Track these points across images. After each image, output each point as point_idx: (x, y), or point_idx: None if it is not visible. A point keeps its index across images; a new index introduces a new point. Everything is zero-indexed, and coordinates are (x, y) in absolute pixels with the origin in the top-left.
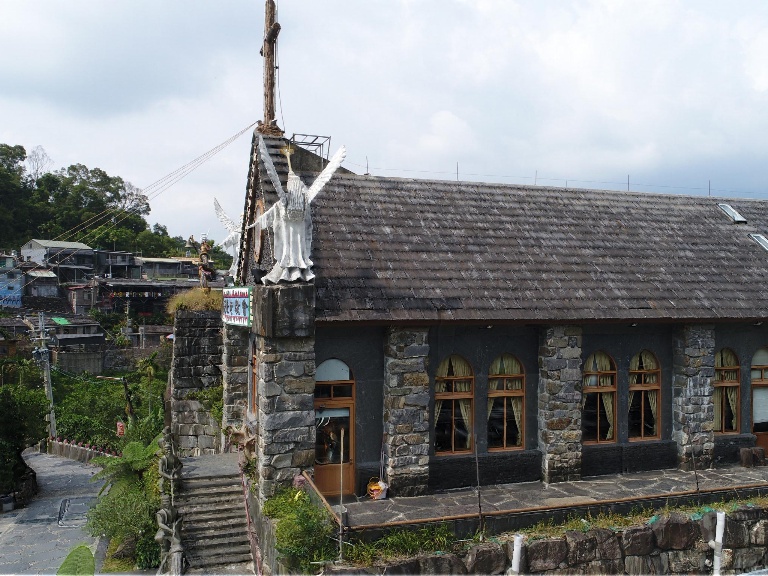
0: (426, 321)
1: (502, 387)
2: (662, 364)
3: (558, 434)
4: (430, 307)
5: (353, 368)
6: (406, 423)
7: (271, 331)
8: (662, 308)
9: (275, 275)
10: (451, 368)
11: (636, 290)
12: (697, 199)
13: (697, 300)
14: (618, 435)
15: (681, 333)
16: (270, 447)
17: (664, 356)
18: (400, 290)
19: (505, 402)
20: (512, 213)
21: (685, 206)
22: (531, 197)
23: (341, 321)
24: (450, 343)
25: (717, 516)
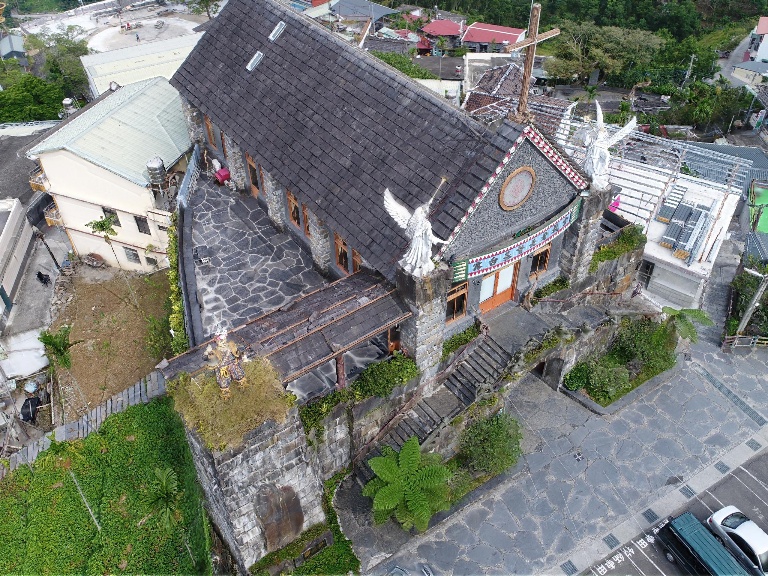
0: None
1: None
2: None
3: None
4: None
5: None
6: None
7: None
8: None
9: (603, 180)
10: None
11: None
12: None
13: None
14: None
15: None
16: None
17: None
18: None
19: None
20: None
21: None
22: None
23: None
24: None
25: None
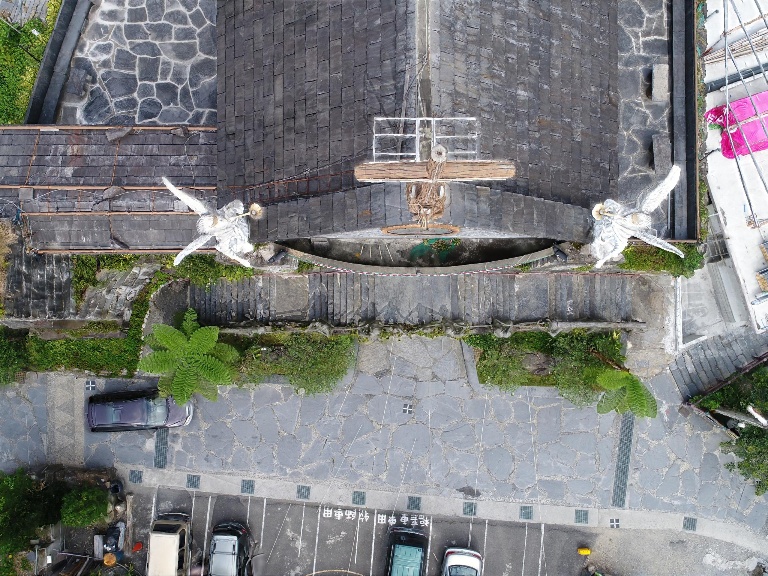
0: None
1: None
2: None
3: None
4: None
5: None
6: None
7: None
8: None
9: None
10: None
11: None
12: None
13: None
14: None
15: None
16: None
17: None
18: (593, 127)
19: None
20: None
21: None
22: None
23: None
24: None
25: None
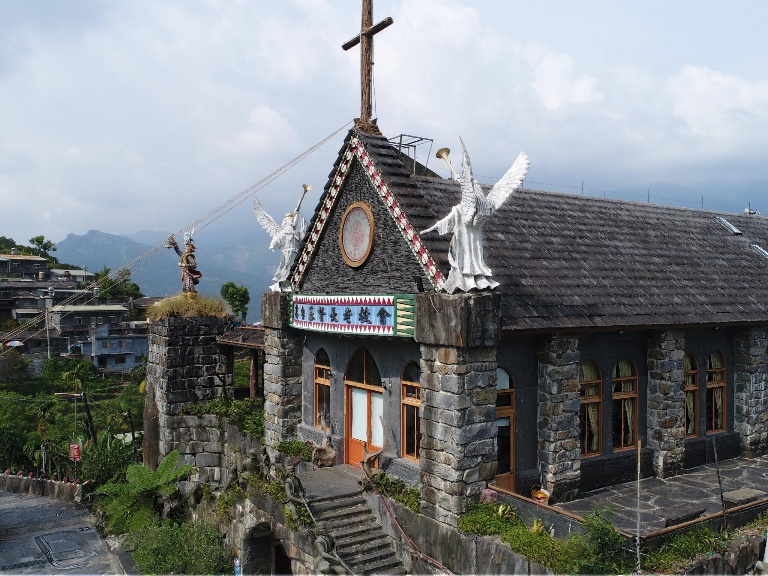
0: (585, 328)
1: (620, 390)
2: (728, 363)
3: (670, 432)
4: (582, 314)
5: (514, 376)
6: (564, 429)
7: (465, 341)
8: (737, 312)
9: (460, 283)
10: (582, 373)
11: (711, 296)
12: (699, 212)
13: (754, 305)
14: (700, 430)
15: (745, 334)
16: (462, 462)
17: (729, 356)
18: (549, 297)
19: (623, 404)
20: (583, 222)
21: (694, 218)
22: (587, 206)
23: (523, 330)
24: (586, 349)
25: None
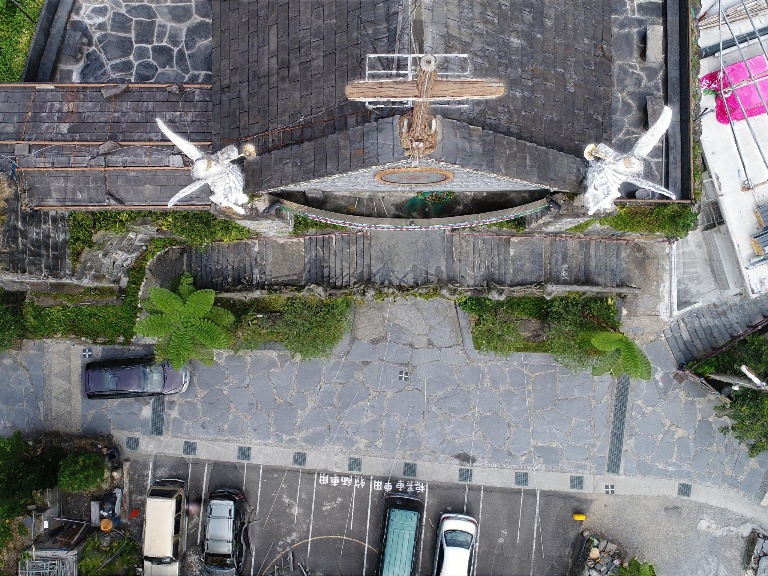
0: None
1: None
2: None
3: None
4: None
5: None
6: None
7: None
8: None
9: None
10: None
11: None
12: None
13: None
14: None
15: None
16: None
17: None
18: (587, 79)
19: None
20: None
21: None
22: None
23: None
24: None
25: None
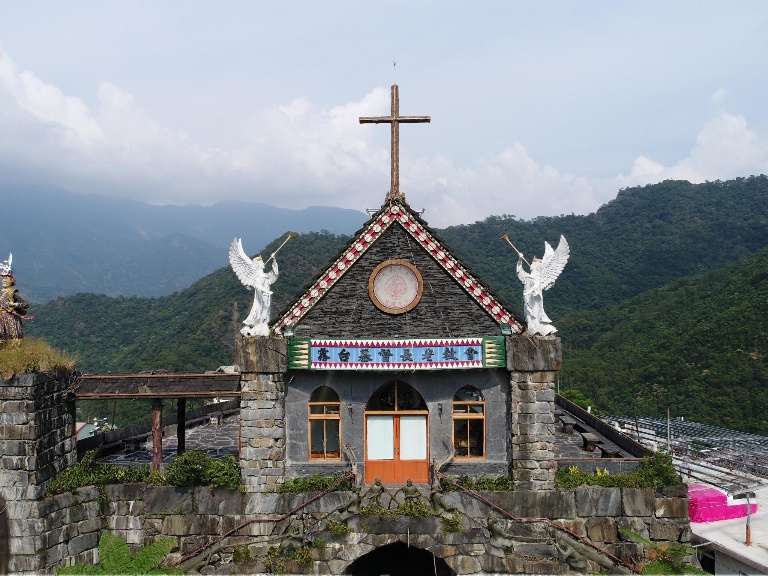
0: None
1: None
2: None
3: None
4: None
5: None
6: None
7: None
8: None
9: None
10: None
11: None
12: None
13: None
14: None
15: None
16: None
17: None
18: None
19: None
20: None
21: None
22: None
23: None
24: None
25: (616, 425)
